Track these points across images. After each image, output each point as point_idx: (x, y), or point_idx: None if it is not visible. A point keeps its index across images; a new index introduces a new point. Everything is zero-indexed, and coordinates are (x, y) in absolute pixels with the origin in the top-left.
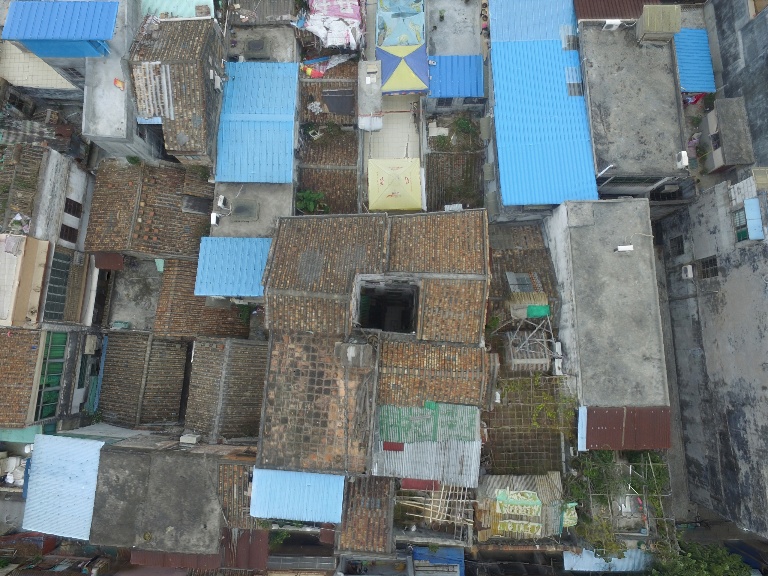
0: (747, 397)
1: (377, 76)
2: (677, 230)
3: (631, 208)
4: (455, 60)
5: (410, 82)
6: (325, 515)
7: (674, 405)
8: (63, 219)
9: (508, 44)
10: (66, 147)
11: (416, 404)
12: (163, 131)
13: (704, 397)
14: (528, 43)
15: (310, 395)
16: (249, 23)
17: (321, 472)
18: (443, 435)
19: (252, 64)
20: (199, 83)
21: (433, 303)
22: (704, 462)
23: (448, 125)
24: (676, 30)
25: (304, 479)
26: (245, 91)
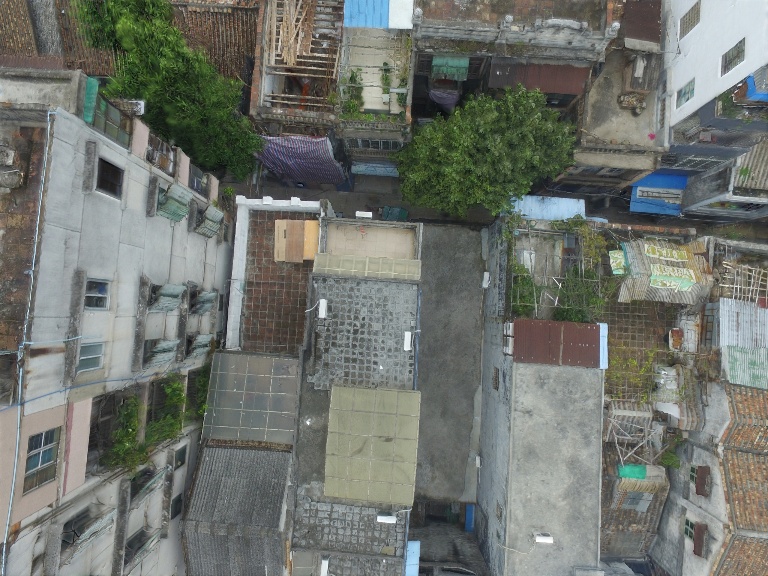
0: None
1: None
2: None
3: None
4: None
5: None
6: None
7: None
8: None
9: None
10: None
11: None
12: None
13: None
14: None
15: None
16: None
17: None
18: (761, 355)
19: None
20: None
21: None
22: None
23: None
24: None
25: None
26: None
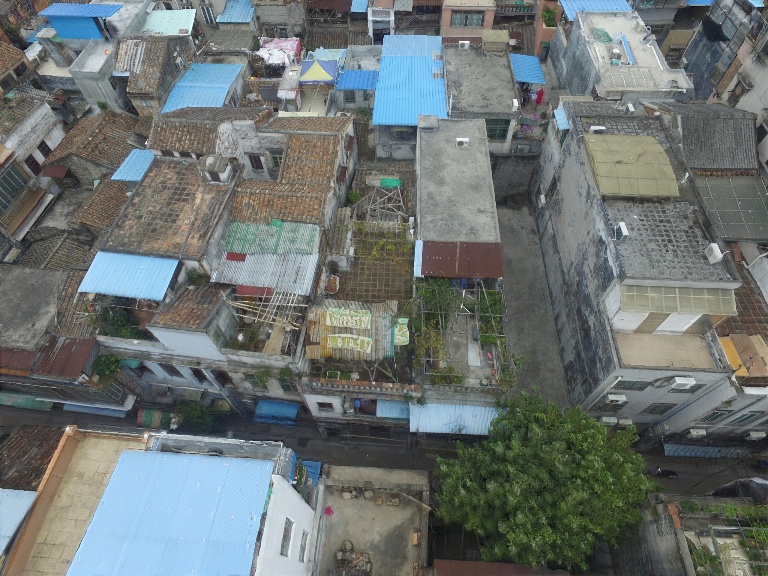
0: (583, 255)
1: (298, 72)
2: (537, 183)
3: (471, 124)
4: (358, 72)
5: (321, 76)
6: (149, 293)
7: (550, 325)
8: (34, 152)
9: (393, 57)
10: (58, 105)
11: (263, 221)
12: (129, 80)
13: (564, 293)
14: (408, 57)
15: (169, 202)
16: (217, 51)
17: (157, 252)
18: (284, 249)
19: (210, 64)
20: (163, 52)
21: (294, 153)
22: (573, 356)
23: (351, 112)
24: (505, 41)
25: (140, 263)
26: (199, 74)
